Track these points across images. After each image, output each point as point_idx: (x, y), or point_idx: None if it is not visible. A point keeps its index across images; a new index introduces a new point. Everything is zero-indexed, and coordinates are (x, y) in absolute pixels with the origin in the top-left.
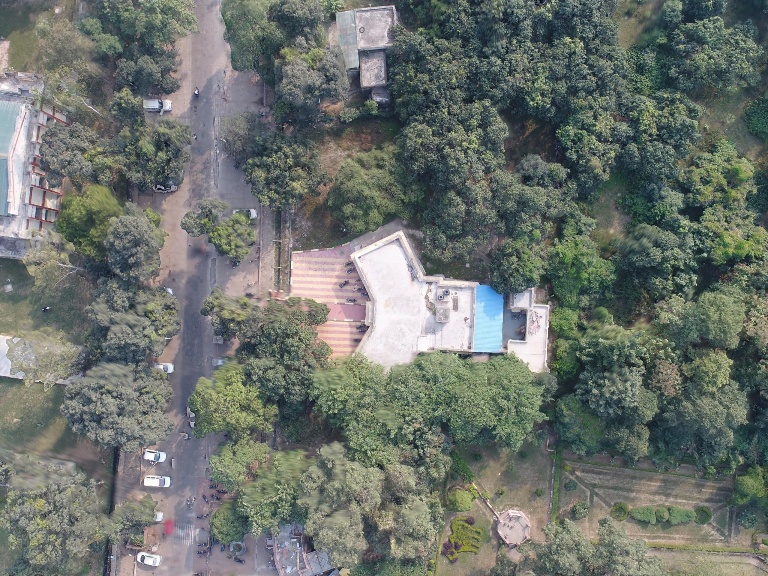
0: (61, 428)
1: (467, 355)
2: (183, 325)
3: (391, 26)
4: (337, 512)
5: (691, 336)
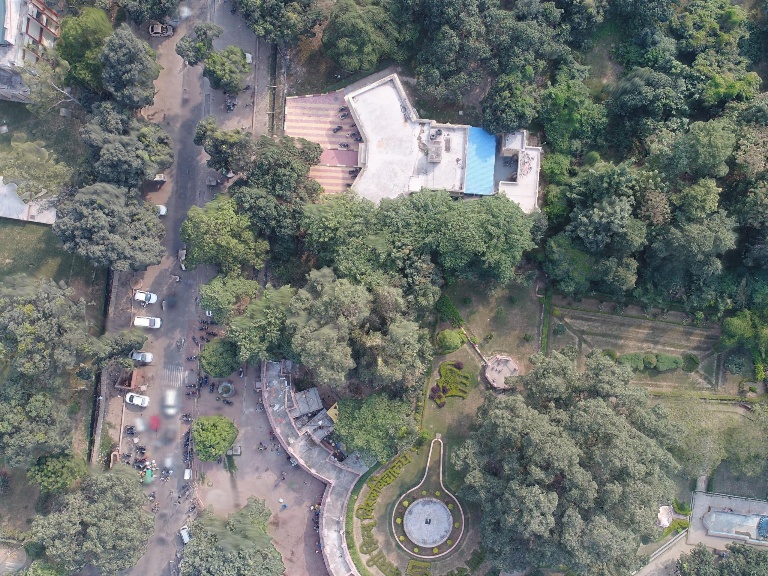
0: (53, 269)
1: (458, 197)
2: (177, 168)
3: None
4: (325, 326)
5: (681, 164)
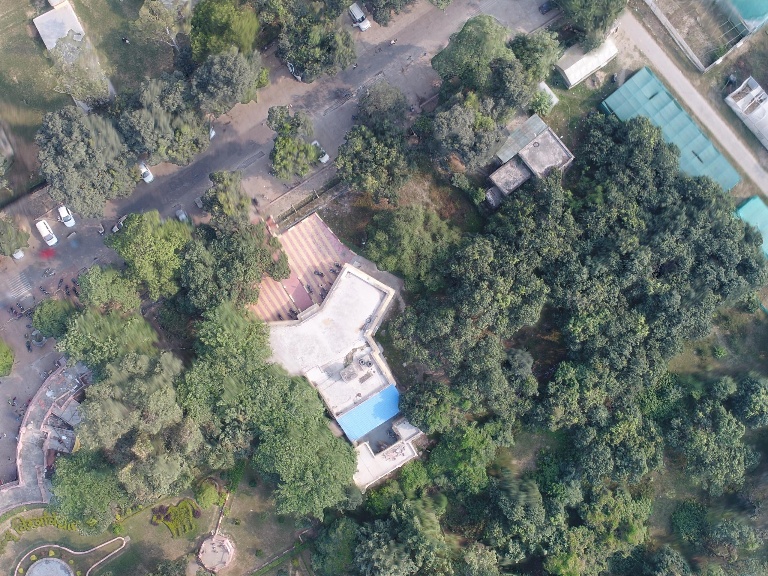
0: (35, 121)
1: (330, 416)
2: (192, 164)
3: (556, 166)
4: (121, 404)
5: None
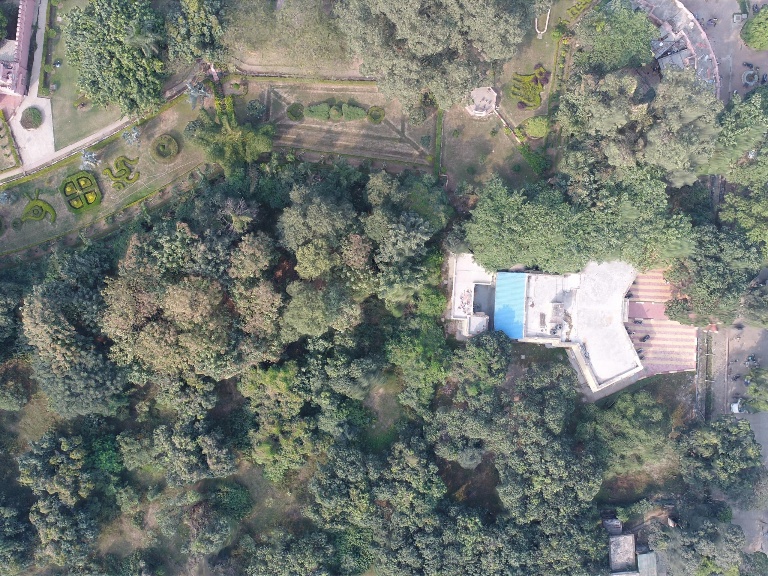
0: None
1: (531, 270)
2: None
3: None
4: None
5: None
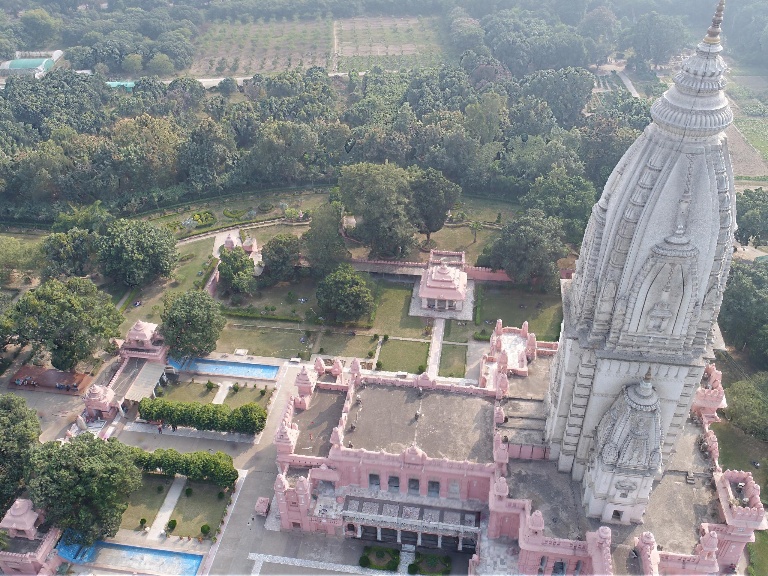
0: None
1: None
2: None
3: None
4: None
5: None
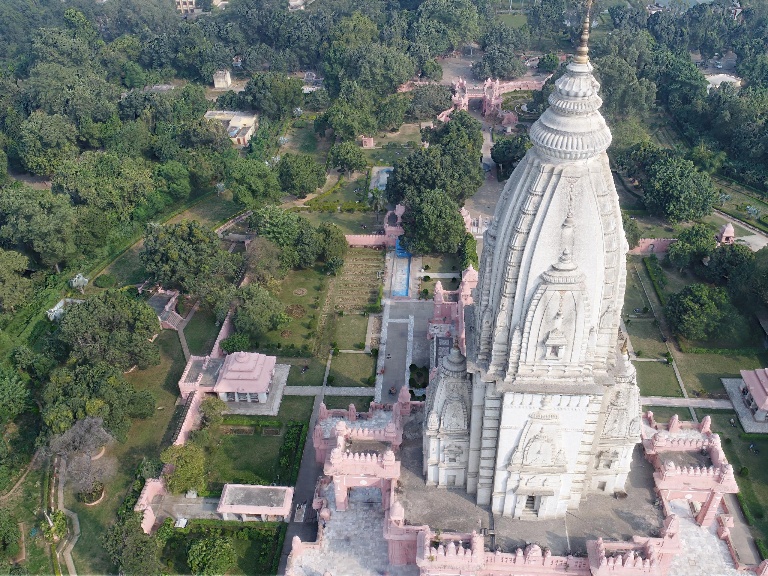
0: None
1: None
2: None
3: None
4: None
5: None
